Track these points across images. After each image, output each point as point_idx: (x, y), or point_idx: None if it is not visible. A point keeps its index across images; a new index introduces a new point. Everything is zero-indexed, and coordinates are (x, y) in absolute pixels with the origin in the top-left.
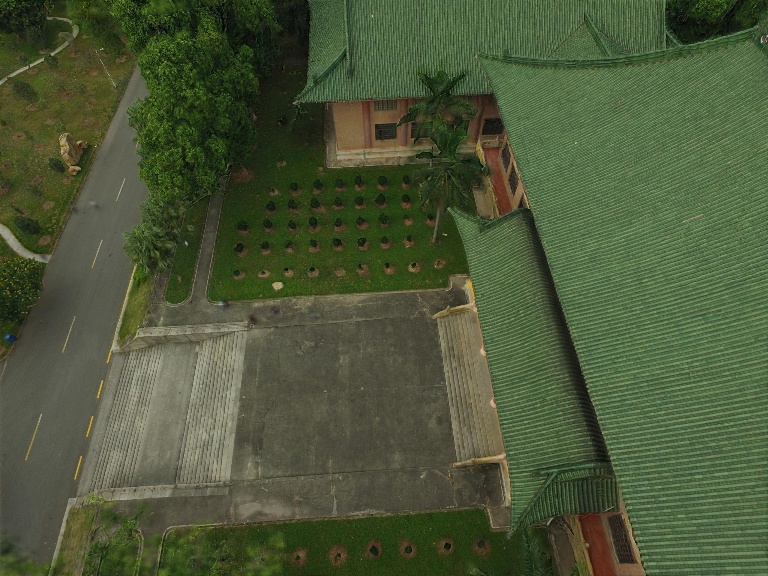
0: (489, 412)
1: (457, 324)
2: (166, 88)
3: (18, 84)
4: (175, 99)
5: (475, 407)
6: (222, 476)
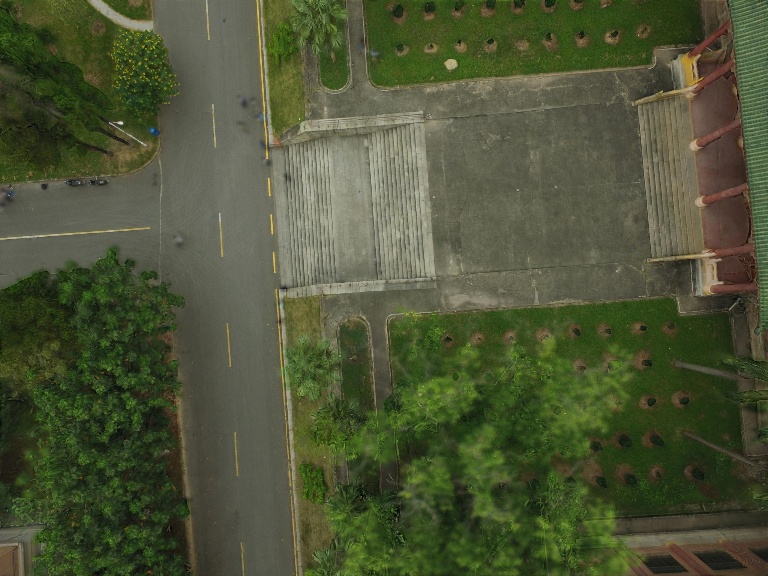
0: (693, 211)
1: (663, 112)
2: None
3: None
4: None
5: (677, 206)
6: (427, 272)
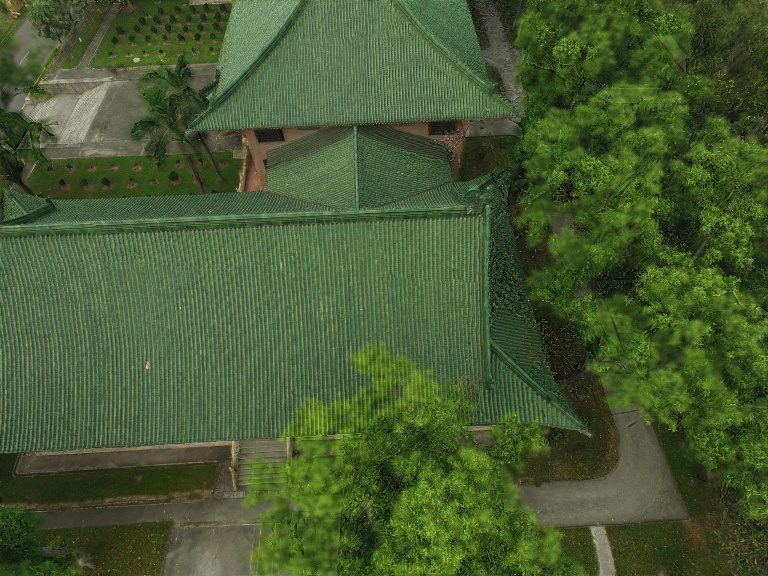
0: None
1: None
2: None
3: None
4: None
5: None
6: (78, 141)
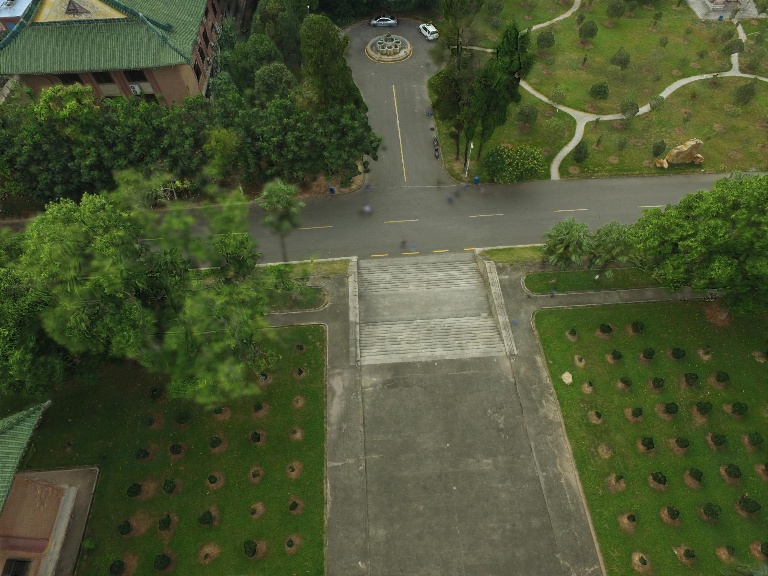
0: None
1: None
2: (766, 190)
3: (749, 86)
4: (756, 204)
5: None
6: (365, 358)
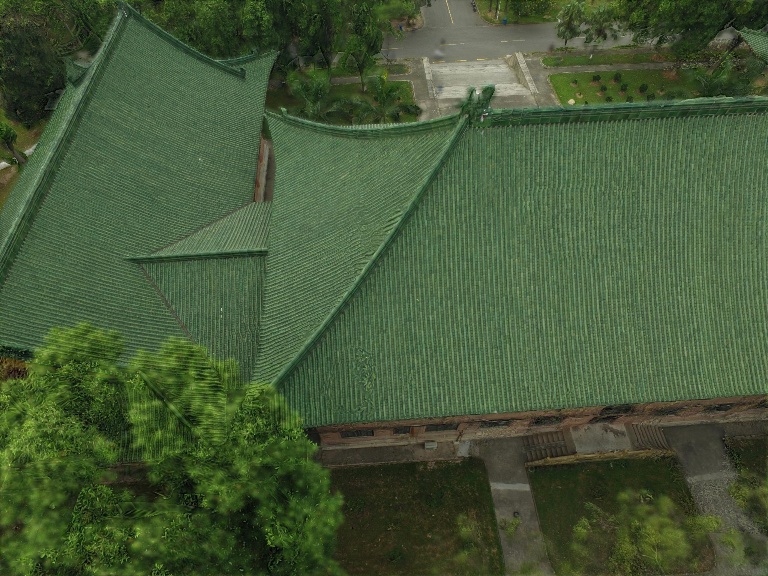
0: None
1: None
2: None
3: None
4: None
5: None
6: (439, 96)
